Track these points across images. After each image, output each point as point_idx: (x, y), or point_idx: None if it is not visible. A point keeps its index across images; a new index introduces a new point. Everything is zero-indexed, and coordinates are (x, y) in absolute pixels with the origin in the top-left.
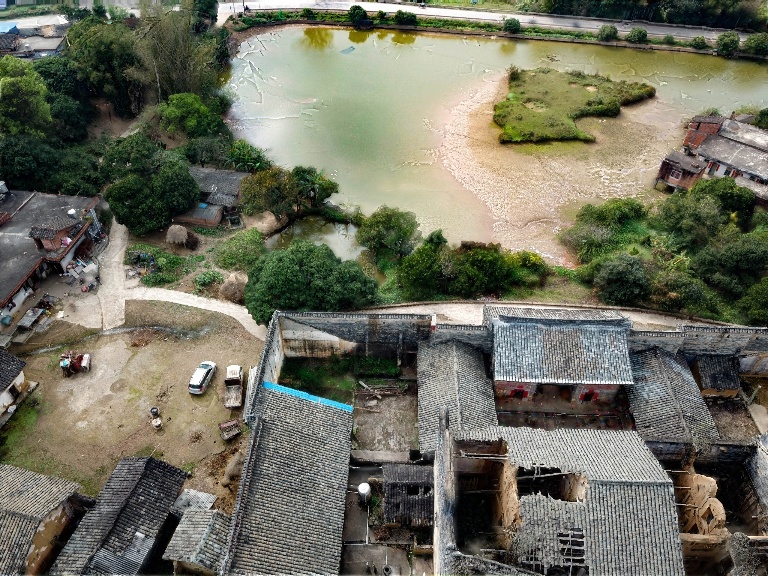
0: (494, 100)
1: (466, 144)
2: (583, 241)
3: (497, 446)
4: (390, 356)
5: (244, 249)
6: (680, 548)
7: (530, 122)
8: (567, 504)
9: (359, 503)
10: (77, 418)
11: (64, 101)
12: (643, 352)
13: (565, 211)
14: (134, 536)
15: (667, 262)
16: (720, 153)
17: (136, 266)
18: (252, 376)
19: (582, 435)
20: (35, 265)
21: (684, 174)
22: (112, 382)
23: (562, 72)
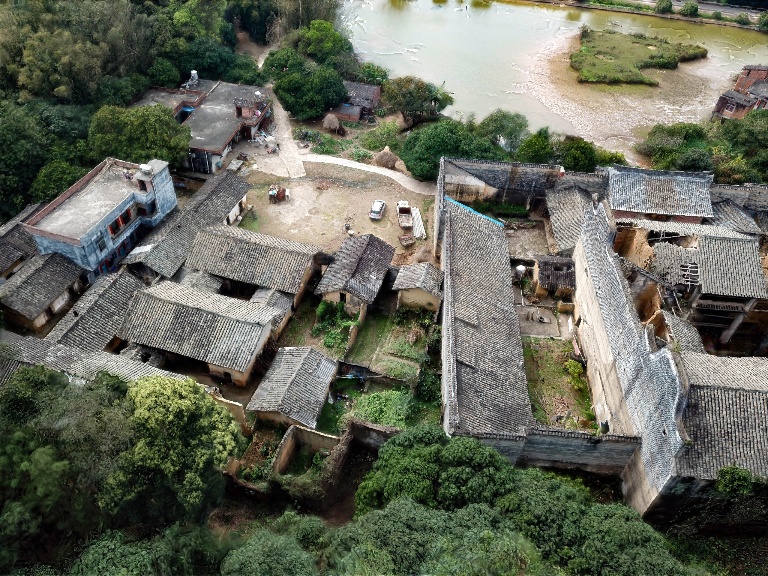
0: (569, 52)
1: (549, 81)
2: (658, 146)
3: (626, 232)
4: (521, 203)
5: (388, 135)
6: (763, 277)
7: (603, 68)
8: (686, 249)
9: (513, 283)
10: (289, 227)
11: (221, 21)
12: (718, 203)
13: (638, 132)
14: (369, 277)
15: (727, 164)
16: (767, 92)
17: (304, 141)
18: (414, 212)
19: (688, 225)
20: (239, 126)
21: (737, 107)
22: (309, 209)
23: (626, 34)
